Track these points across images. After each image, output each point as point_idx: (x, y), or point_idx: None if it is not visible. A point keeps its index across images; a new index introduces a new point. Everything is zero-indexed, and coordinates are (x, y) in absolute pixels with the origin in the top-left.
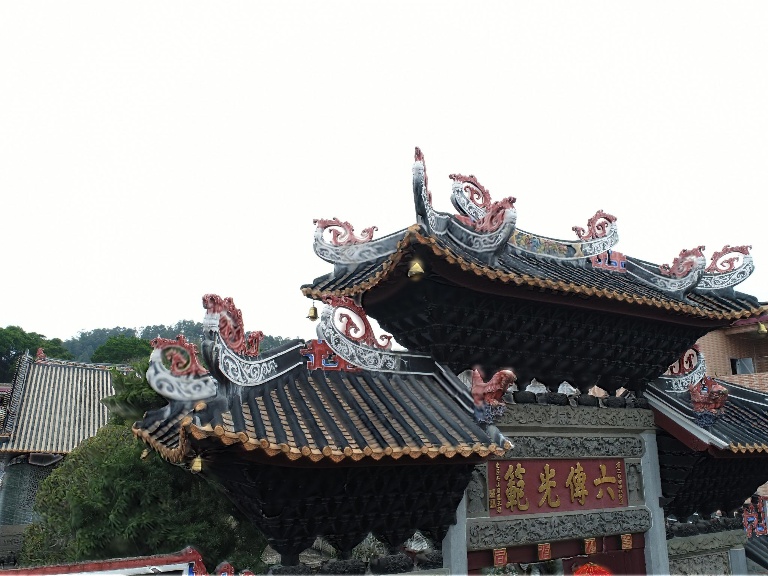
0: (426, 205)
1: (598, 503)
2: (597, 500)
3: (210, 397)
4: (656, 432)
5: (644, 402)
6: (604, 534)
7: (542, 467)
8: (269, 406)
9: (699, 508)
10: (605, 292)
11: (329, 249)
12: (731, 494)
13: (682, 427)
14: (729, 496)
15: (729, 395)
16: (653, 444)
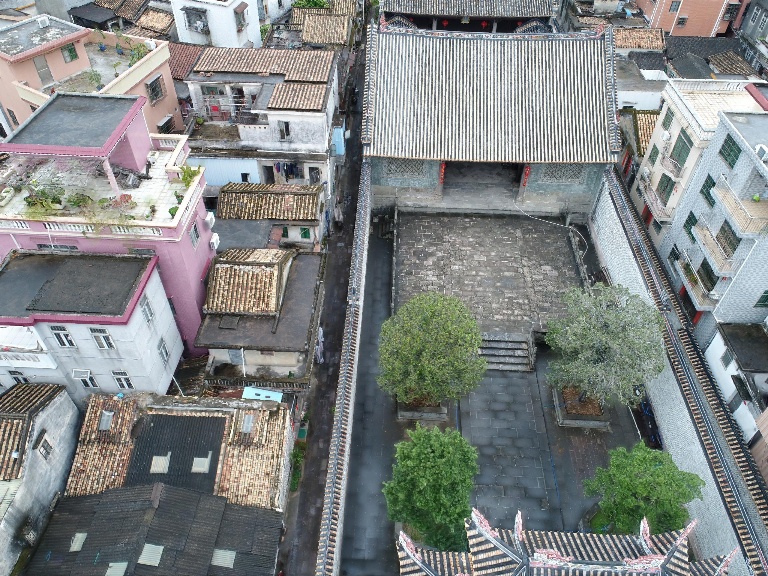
0: None
1: None
2: None
3: (418, 564)
4: None
5: None
6: None
7: None
8: None
9: None
10: None
11: (477, 524)
12: None
13: None
14: None
15: None
16: None
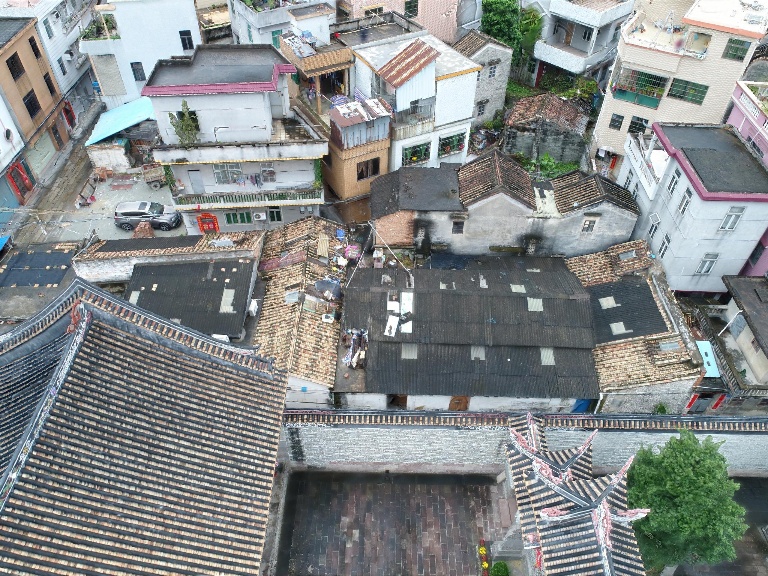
0: (538, 475)
1: None
2: None
3: None
4: None
5: None
6: None
7: None
8: (526, 463)
9: None
10: None
11: None
12: None
13: None
14: None
15: None
16: None
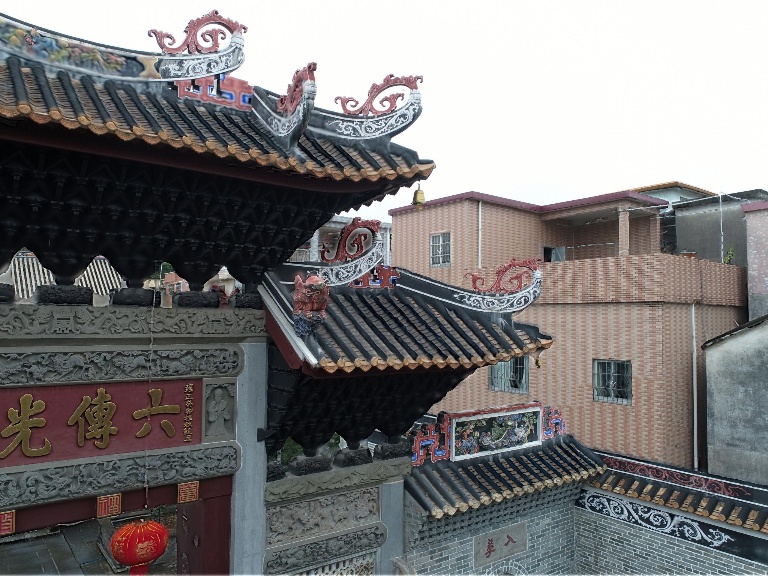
0: None
1: (139, 443)
2: (138, 439)
3: None
4: (269, 340)
5: (255, 299)
6: (142, 486)
7: (16, 399)
8: None
9: (343, 435)
10: (55, 116)
11: None
12: (386, 417)
13: (284, 335)
14: (383, 419)
15: (412, 289)
16: (259, 357)
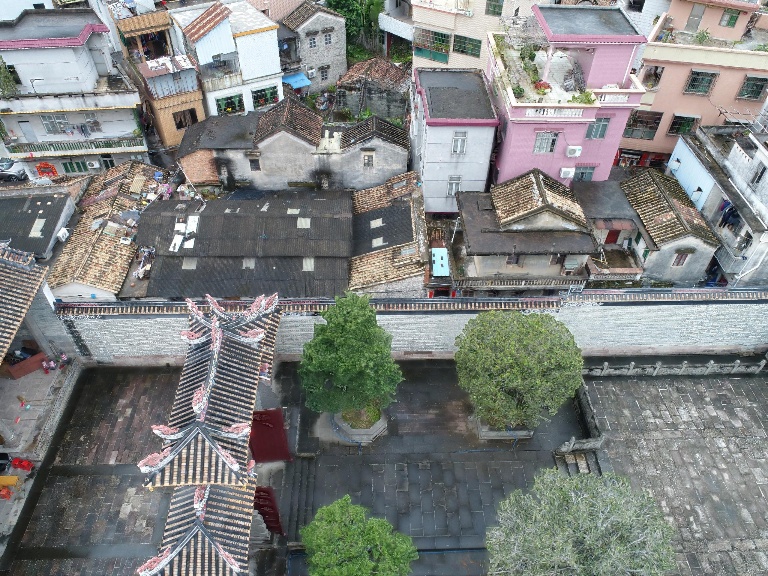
0: None
1: None
2: None
3: None
4: None
5: None
6: None
7: None
8: None
9: None
10: None
11: None
12: None
13: None
14: None
15: None
16: None
